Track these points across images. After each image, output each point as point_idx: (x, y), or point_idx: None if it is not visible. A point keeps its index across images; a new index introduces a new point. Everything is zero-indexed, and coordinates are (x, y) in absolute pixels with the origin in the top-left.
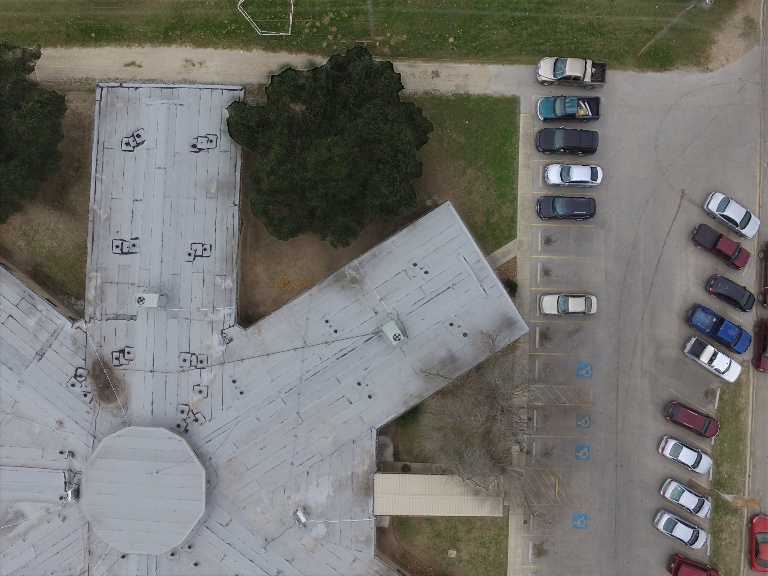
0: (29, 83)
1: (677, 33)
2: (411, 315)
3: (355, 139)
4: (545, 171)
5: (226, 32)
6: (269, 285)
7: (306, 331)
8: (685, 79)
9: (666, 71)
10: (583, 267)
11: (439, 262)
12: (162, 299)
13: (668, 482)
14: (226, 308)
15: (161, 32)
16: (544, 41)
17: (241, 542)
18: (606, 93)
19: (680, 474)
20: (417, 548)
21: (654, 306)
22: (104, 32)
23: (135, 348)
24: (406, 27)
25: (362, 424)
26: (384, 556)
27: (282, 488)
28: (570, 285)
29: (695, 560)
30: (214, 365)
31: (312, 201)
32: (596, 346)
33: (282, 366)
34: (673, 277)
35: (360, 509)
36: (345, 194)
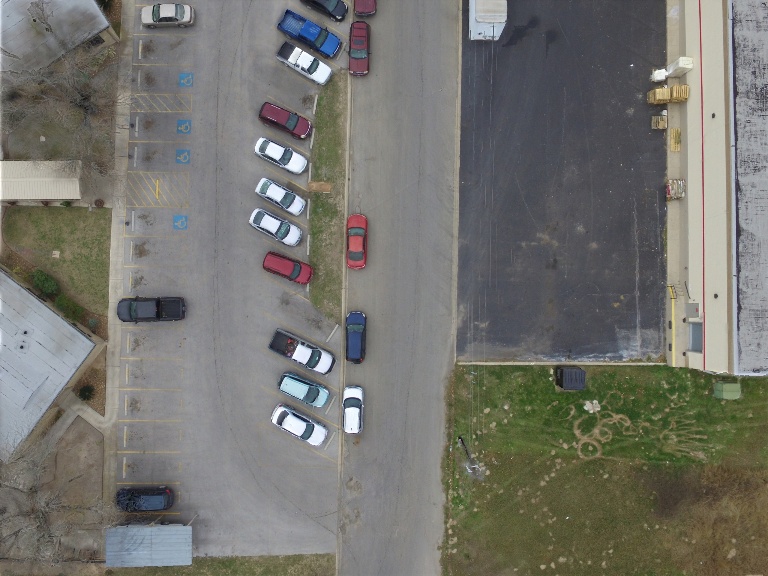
0: None
1: None
2: None
3: None
4: None
5: None
6: None
7: None
8: None
9: None
10: None
11: None
12: None
13: None
14: None
15: None
16: None
17: None
18: None
19: (279, 177)
20: (23, 249)
21: (253, 19)
22: None
23: None
24: None
25: None
26: None
27: None
28: (173, 1)
29: (292, 258)
30: None
31: None
32: (197, 57)
33: None
34: None
35: None
36: None
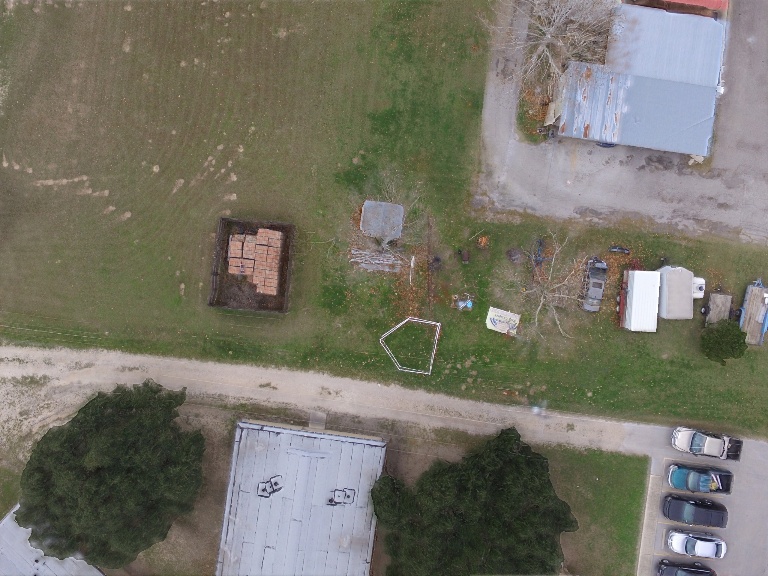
0: (174, 432)
1: None
2: None
3: (505, 547)
4: (670, 537)
5: (365, 364)
6: None
7: None
8: None
9: None
10: None
11: None
12: None
13: None
14: None
15: (300, 357)
16: (681, 404)
17: None
18: None
19: None
20: None
21: None
22: (242, 351)
23: None
24: (546, 378)
25: None
26: None
27: None
28: None
29: None
30: None
31: None
32: None
33: None
34: None
35: None
36: None
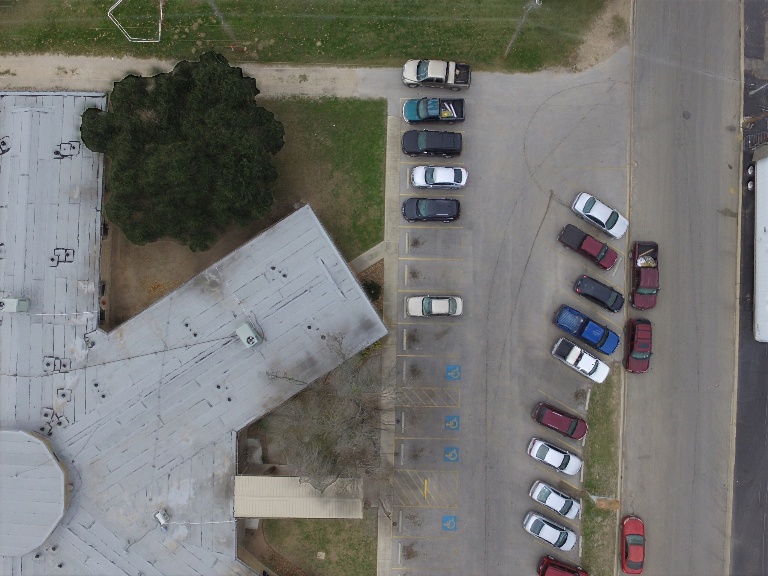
0: None
1: (545, 33)
2: (269, 318)
3: (200, 144)
4: (411, 173)
5: (97, 39)
6: (139, 289)
7: (167, 335)
8: (553, 79)
9: (534, 72)
10: (451, 269)
11: (298, 265)
12: (22, 304)
13: (536, 484)
14: (88, 313)
15: (34, 40)
16: (411, 43)
17: (104, 544)
18: (474, 94)
19: (550, 476)
20: (286, 550)
21: (523, 307)
22: None
23: (0, 353)
24: (274, 32)
25: (222, 427)
26: (253, 558)
27: (144, 490)
28: (438, 287)
29: (566, 562)
30: (77, 369)
31: (159, 206)
32: (464, 348)
33: (143, 370)
34: (542, 278)
35: (221, 511)
36: (192, 199)
